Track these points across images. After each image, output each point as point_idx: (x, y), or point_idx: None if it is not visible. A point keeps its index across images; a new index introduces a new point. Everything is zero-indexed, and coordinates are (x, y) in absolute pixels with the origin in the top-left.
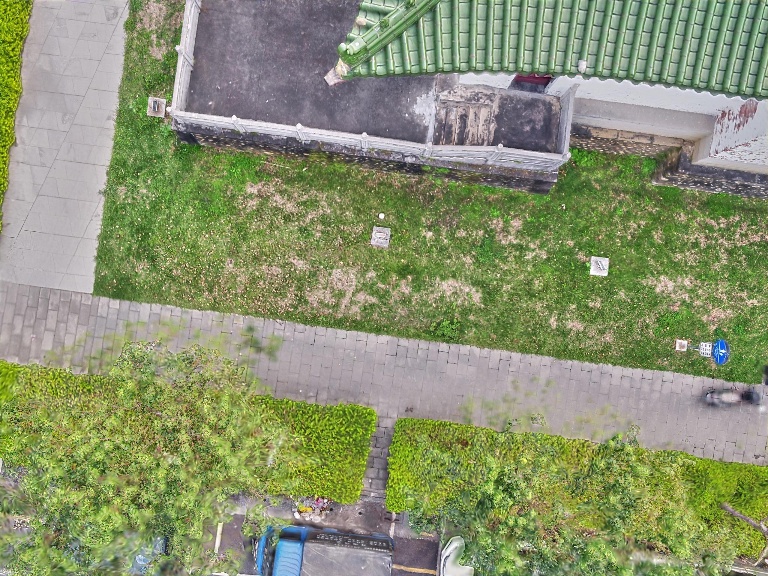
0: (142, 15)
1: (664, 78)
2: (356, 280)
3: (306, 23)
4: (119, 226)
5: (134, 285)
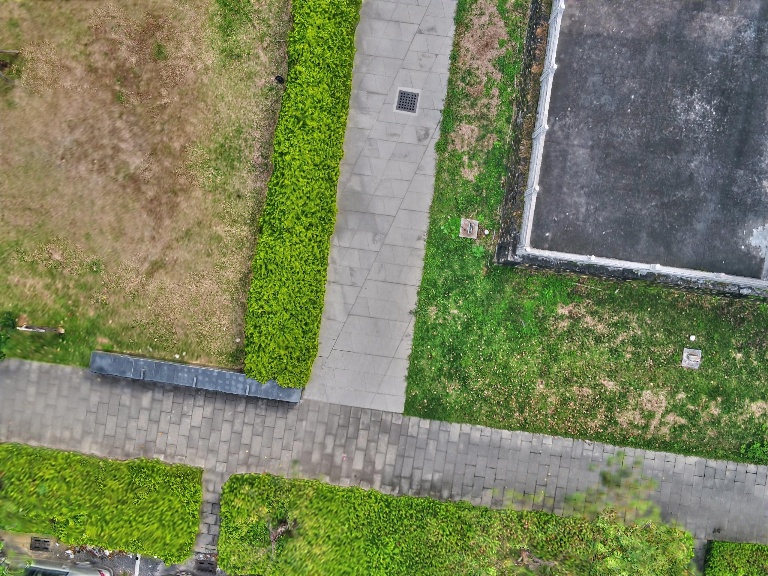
0: (454, 136)
1: None
2: (666, 401)
3: (643, 155)
4: (430, 346)
5: (445, 405)
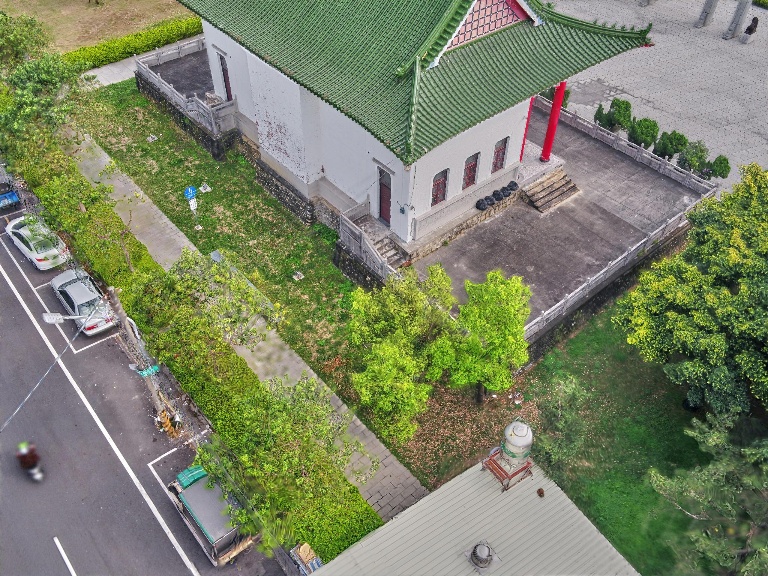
0: None
1: (192, 6)
2: (128, 143)
3: None
4: None
5: None
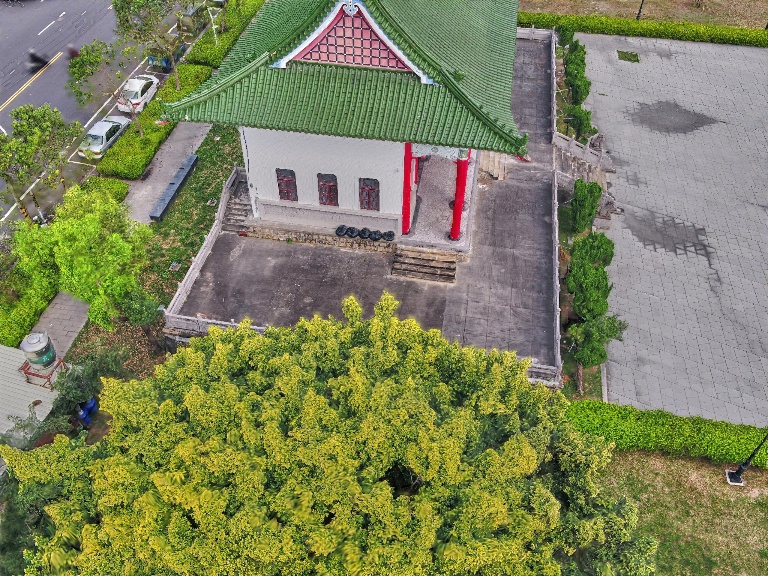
0: None
1: None
2: None
3: None
4: None
5: None
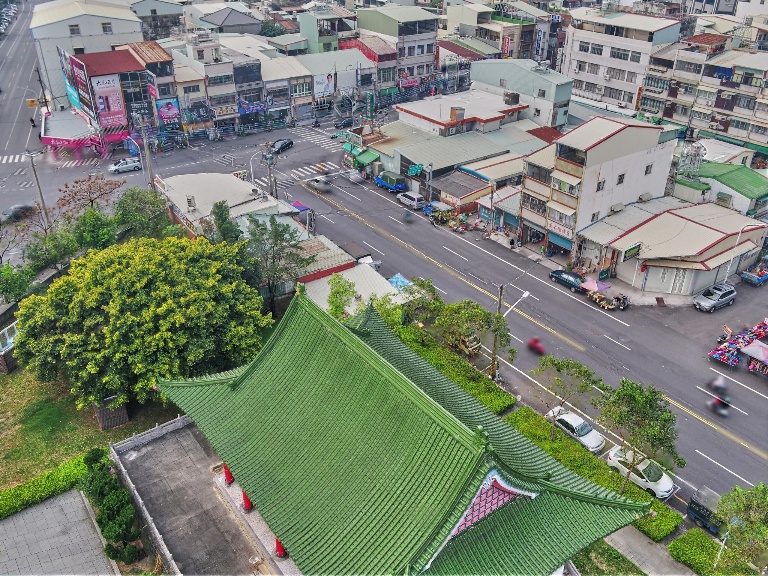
0: None
1: None
2: None
3: None
4: None
5: None
